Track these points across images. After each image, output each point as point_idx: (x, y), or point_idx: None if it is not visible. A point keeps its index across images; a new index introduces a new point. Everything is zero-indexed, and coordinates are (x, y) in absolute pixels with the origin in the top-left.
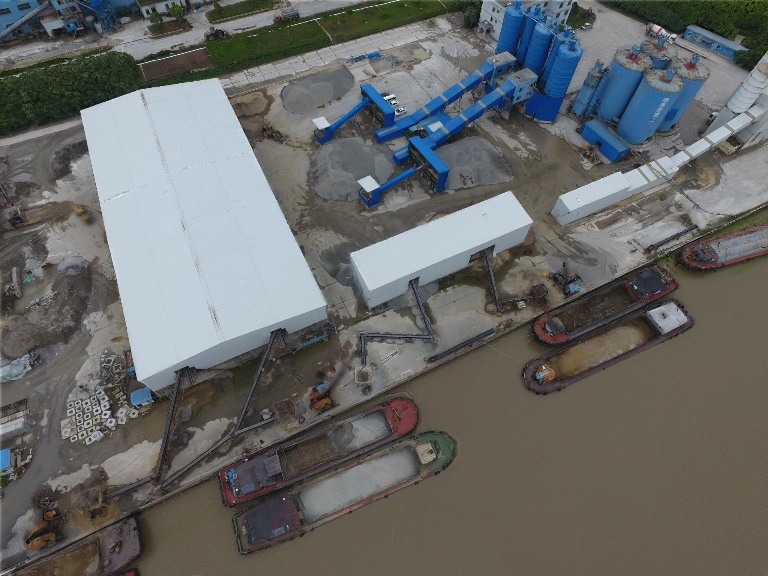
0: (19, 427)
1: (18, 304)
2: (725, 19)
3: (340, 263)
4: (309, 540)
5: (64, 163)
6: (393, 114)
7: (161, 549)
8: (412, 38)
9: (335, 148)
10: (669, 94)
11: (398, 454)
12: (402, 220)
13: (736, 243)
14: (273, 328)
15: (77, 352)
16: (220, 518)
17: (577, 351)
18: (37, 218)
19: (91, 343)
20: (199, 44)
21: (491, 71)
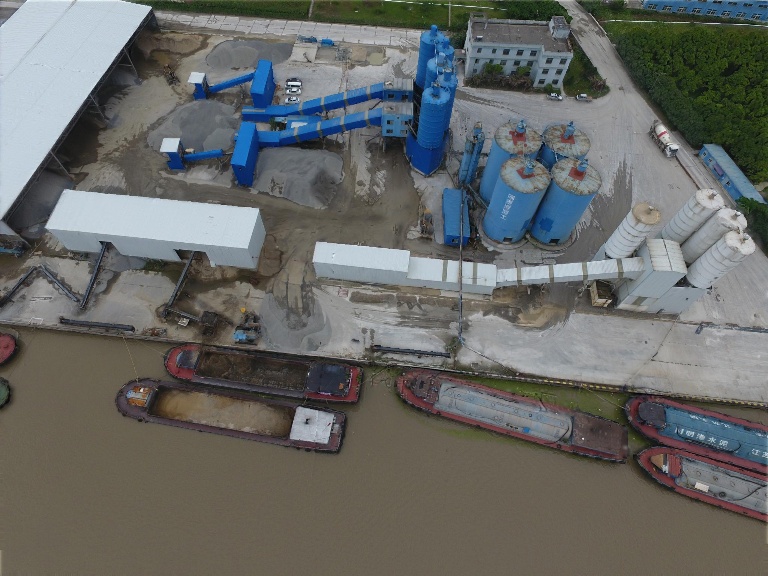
0: None
1: None
2: (760, 153)
3: None
4: None
5: None
6: (261, 96)
7: None
8: (385, 41)
9: (193, 105)
10: (513, 191)
11: None
12: (185, 194)
13: (472, 399)
14: None
15: None
16: None
17: (195, 398)
18: None
19: None
20: None
21: (379, 92)
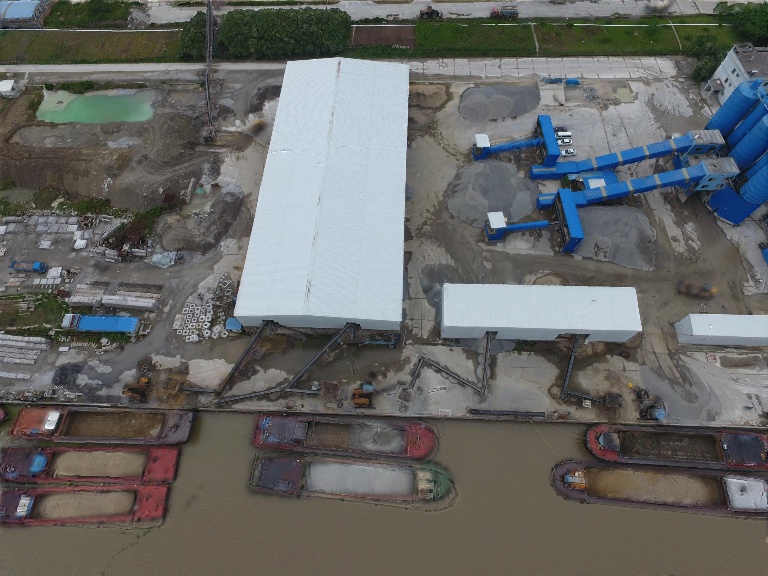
0: (149, 306)
1: (185, 208)
2: None
3: (436, 283)
4: (302, 503)
5: (260, 100)
6: (557, 156)
7: (201, 445)
8: (624, 74)
9: (484, 170)
10: None
11: (404, 475)
12: (514, 266)
13: None
14: (349, 320)
15: (207, 265)
16: (247, 448)
17: (622, 476)
18: (224, 142)
19: (219, 263)
20: (412, 19)
21: (687, 146)
